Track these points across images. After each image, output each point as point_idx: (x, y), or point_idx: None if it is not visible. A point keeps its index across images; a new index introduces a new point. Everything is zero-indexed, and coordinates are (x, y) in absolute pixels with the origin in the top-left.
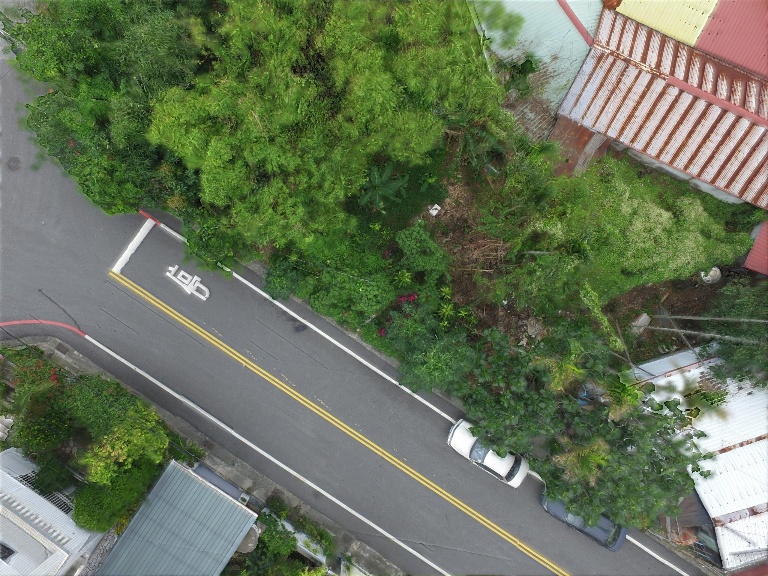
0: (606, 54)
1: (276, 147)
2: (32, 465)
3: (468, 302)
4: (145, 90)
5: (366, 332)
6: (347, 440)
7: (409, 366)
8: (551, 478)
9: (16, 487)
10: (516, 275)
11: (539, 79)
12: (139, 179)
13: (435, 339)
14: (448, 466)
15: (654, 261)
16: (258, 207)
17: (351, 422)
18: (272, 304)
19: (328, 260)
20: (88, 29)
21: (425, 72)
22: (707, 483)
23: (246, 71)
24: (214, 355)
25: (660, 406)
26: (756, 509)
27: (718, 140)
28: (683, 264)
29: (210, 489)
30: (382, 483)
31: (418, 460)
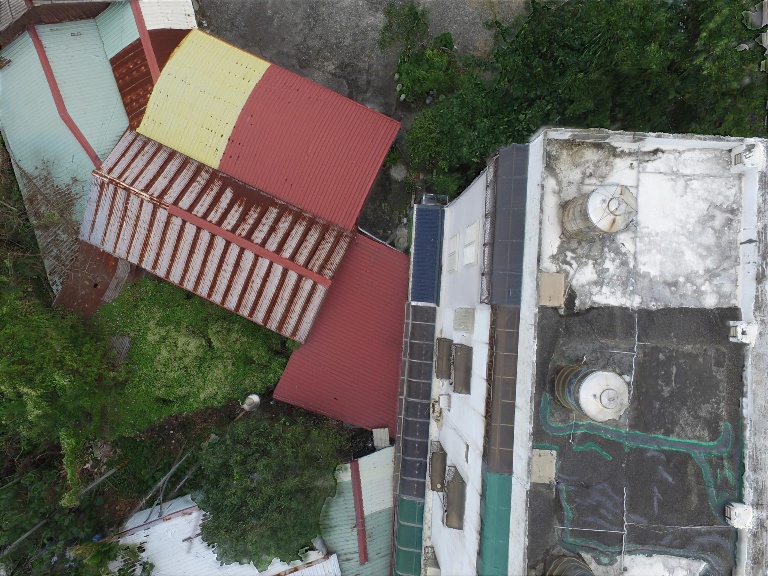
0: (106, 182)
1: None
2: None
3: None
4: None
5: None
6: None
7: None
8: None
9: None
10: None
11: (64, 201)
12: None
13: None
14: None
15: (184, 390)
16: None
17: None
18: None
19: None
20: None
21: None
22: None
23: None
24: None
25: None
26: None
27: (230, 270)
28: (210, 394)
29: None
30: None
31: None
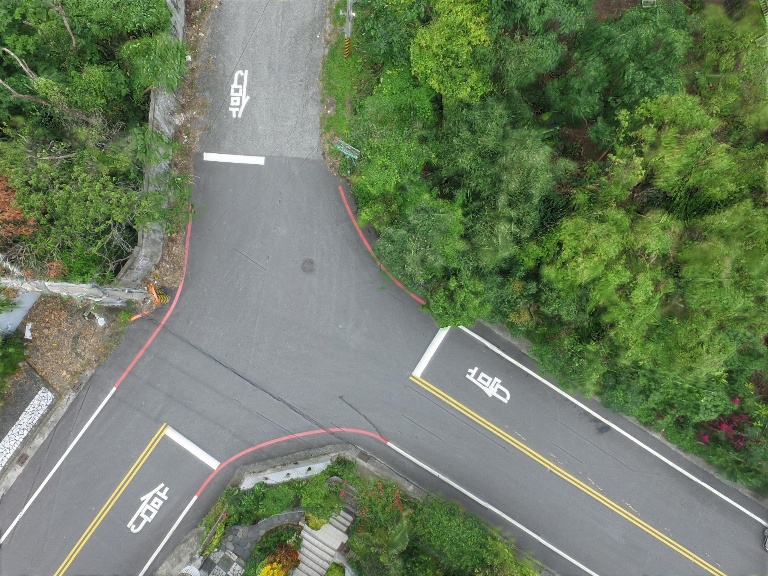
0: None
1: None
2: None
3: (767, 396)
4: (468, 195)
5: (674, 433)
6: (658, 545)
7: None
8: None
9: None
10: None
11: None
12: (492, 297)
13: None
14: (760, 570)
15: None
16: None
17: (661, 526)
18: (574, 405)
19: (641, 361)
20: (400, 131)
21: None
22: None
23: (592, 179)
24: (518, 460)
25: None
26: None
27: None
28: None
29: None
30: None
31: (730, 564)
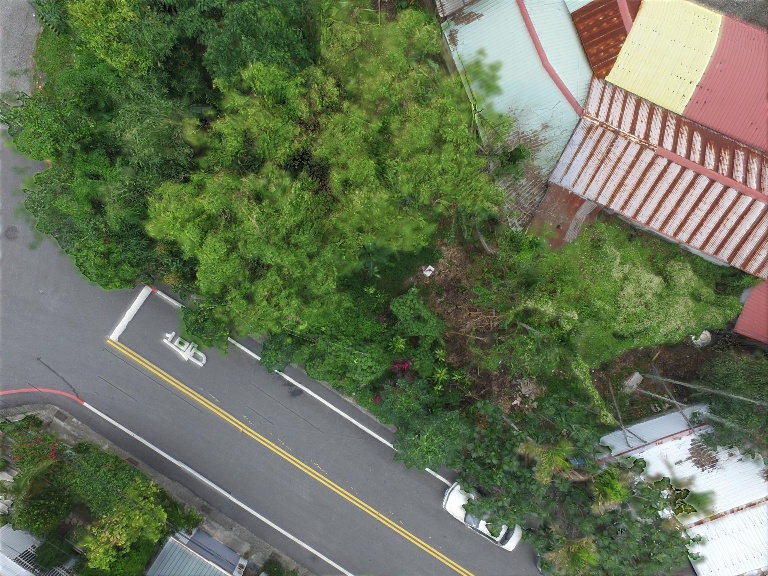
0: (595, 125)
1: (269, 245)
2: (32, 538)
3: (462, 363)
4: (141, 165)
5: (361, 396)
6: (343, 504)
7: (403, 443)
8: (544, 549)
9: (16, 572)
10: (508, 345)
11: (530, 146)
12: (135, 259)
13: (429, 415)
14: (443, 528)
15: (645, 326)
16: (253, 279)
17: (347, 486)
18: None
19: (323, 327)
20: (84, 103)
21: (418, 133)
22: (699, 549)
23: None
24: (211, 421)
25: (649, 490)
26: (747, 575)
27: (707, 208)
28: (673, 329)
29: (208, 565)
30: (378, 546)
31: (414, 522)
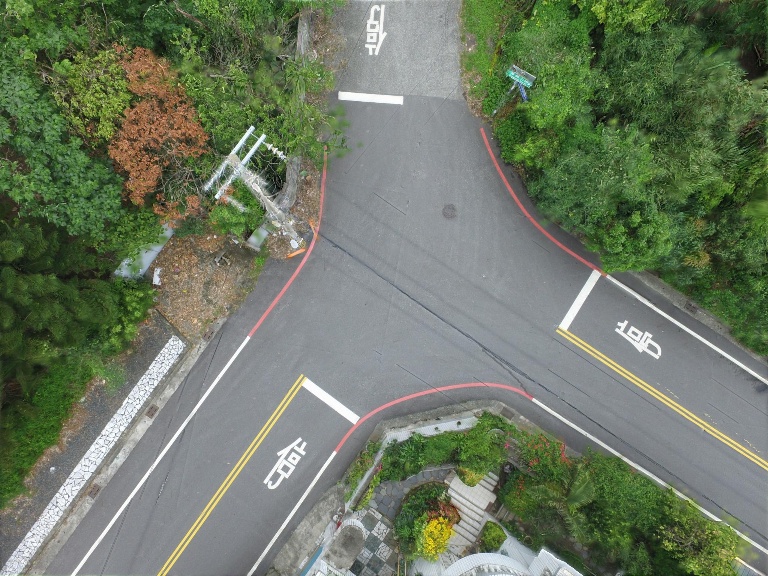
0: None
1: None
2: (529, 550)
3: None
4: None
5: None
6: None
7: None
8: None
9: None
10: None
11: None
12: (675, 236)
13: None
14: None
15: None
16: None
17: None
18: (729, 362)
19: None
20: None
21: None
22: None
23: None
24: (670, 419)
25: None
26: None
27: None
28: None
29: None
30: None
31: None
